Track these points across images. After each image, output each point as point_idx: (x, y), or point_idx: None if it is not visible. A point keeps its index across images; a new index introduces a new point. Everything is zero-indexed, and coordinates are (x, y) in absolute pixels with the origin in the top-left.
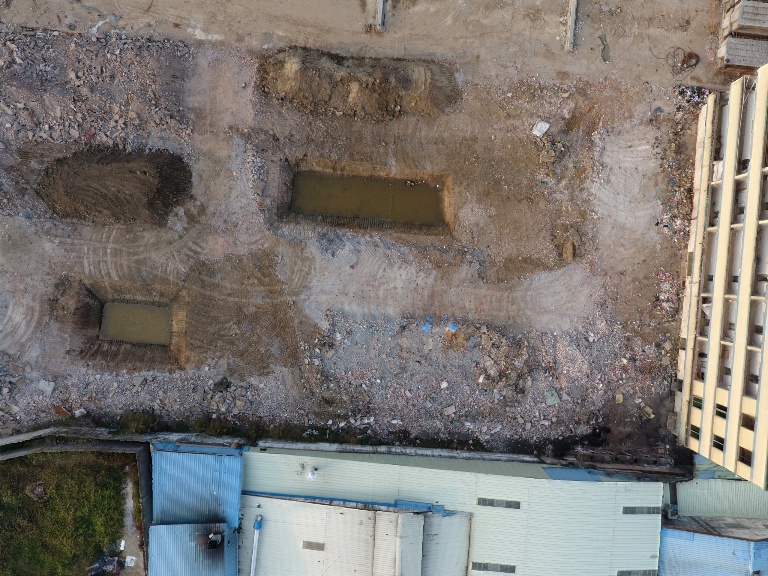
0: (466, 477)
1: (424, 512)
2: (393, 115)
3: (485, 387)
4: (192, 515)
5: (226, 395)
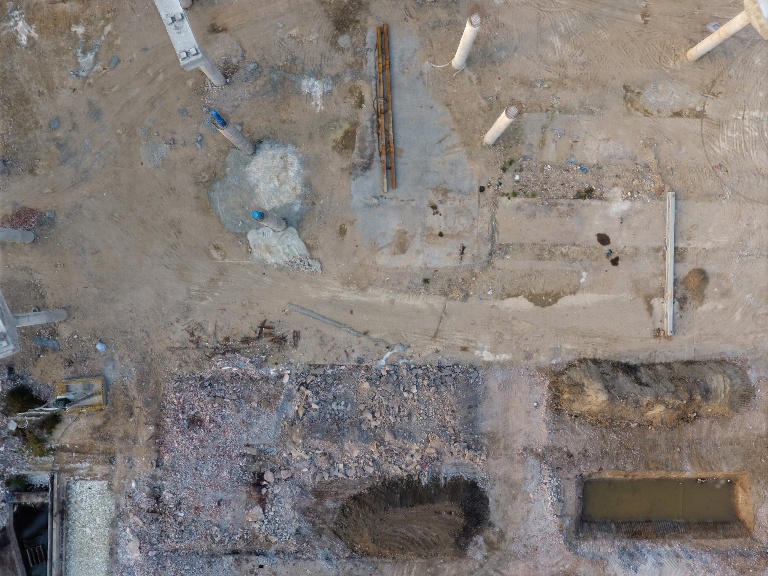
0: None
1: None
2: (687, 420)
3: None
4: None
5: None
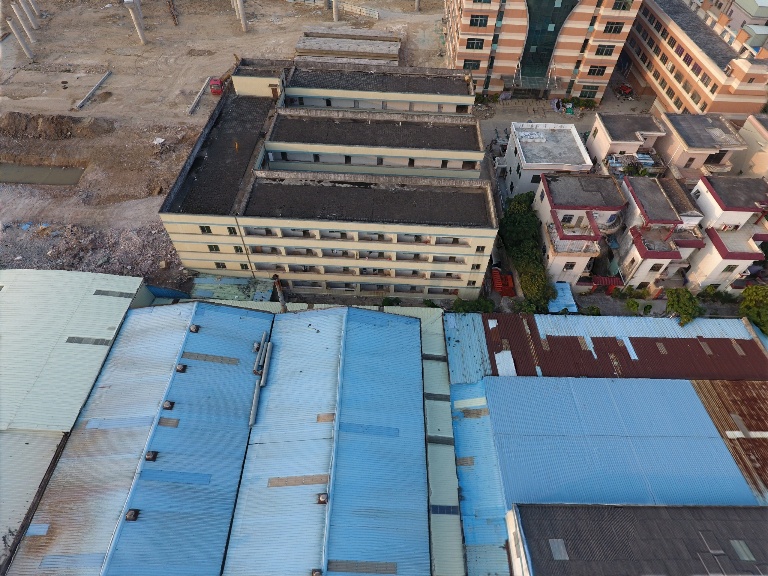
0: None
1: None
2: (65, 137)
3: (52, 259)
4: None
5: None
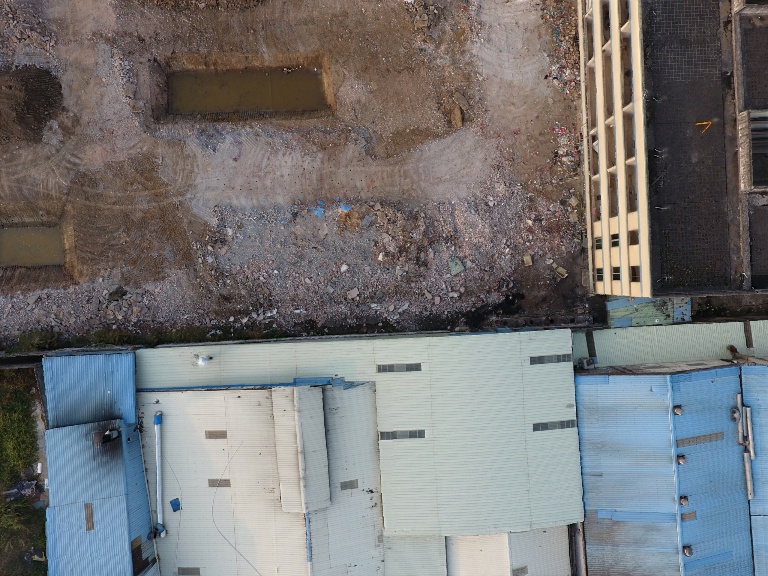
0: (362, 345)
1: (323, 385)
2: (257, 0)
3: (387, 265)
4: (88, 416)
5: (122, 303)
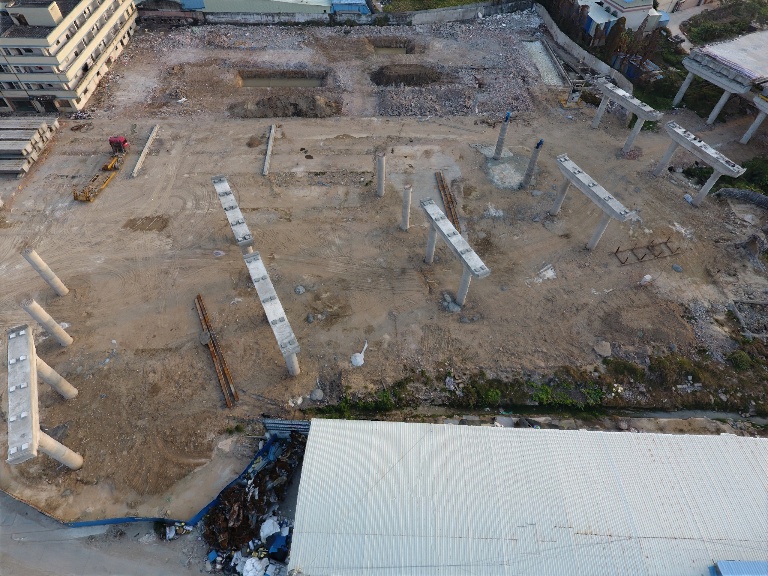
0: None
1: None
2: None
3: None
4: None
5: (345, 29)
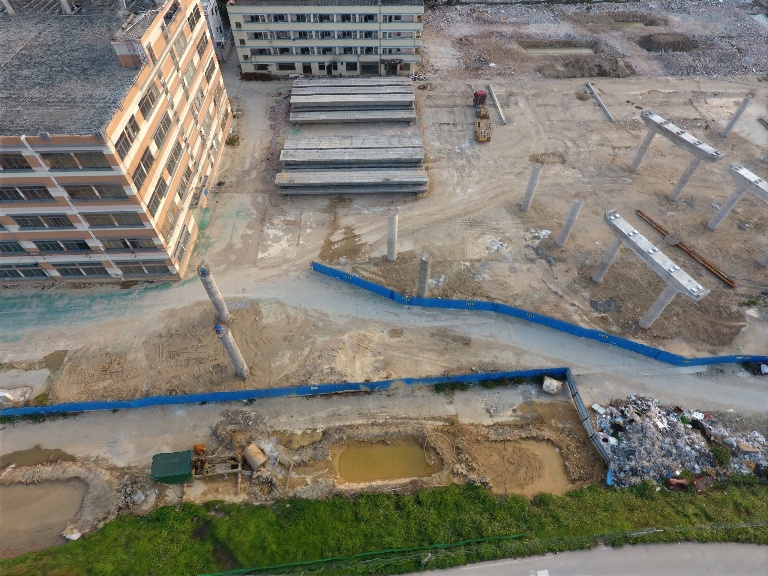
0: None
1: None
2: None
3: None
4: None
5: (586, 6)
